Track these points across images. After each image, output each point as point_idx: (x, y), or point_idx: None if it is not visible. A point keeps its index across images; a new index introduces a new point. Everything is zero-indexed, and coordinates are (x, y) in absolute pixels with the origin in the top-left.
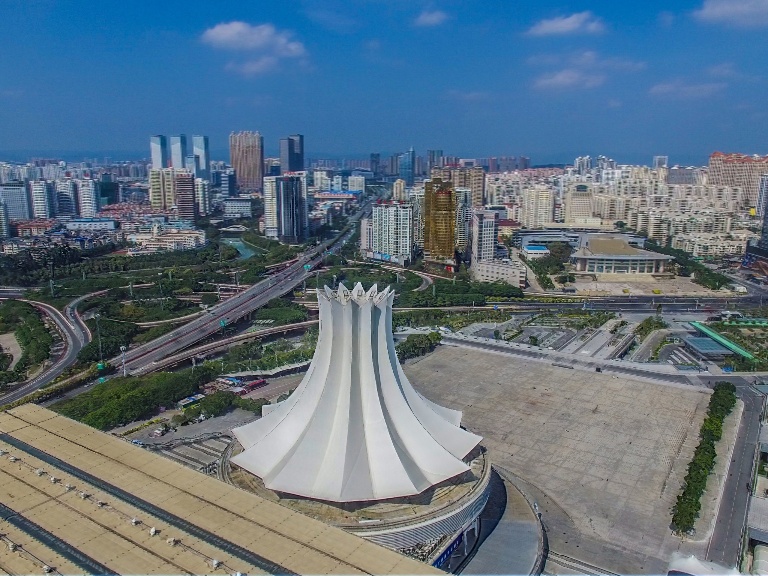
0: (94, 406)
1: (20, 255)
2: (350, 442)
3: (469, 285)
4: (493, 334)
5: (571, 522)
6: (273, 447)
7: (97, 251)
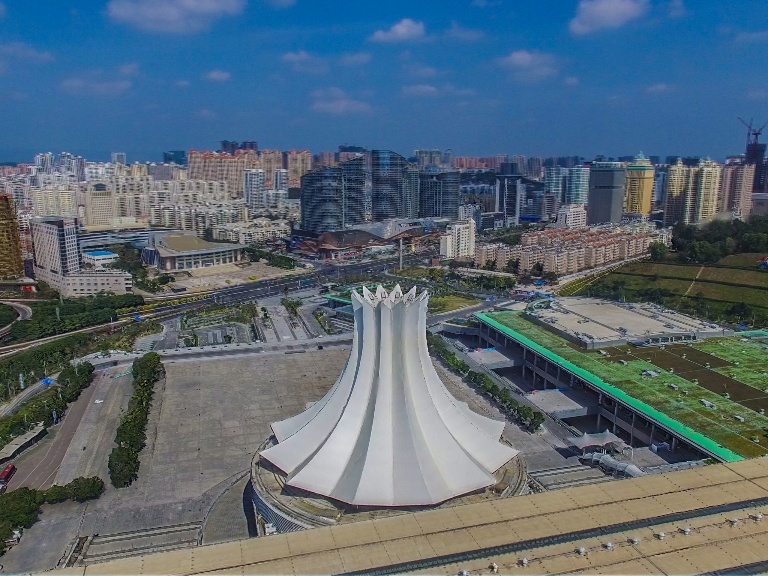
0: None
1: None
2: None
3: (76, 302)
4: (172, 344)
5: None
6: (377, 473)
7: None
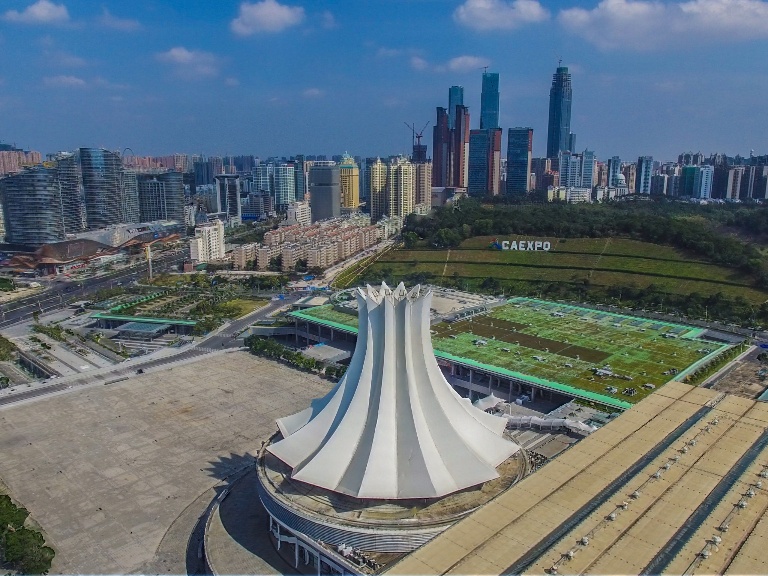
0: None
1: None
2: (469, 414)
3: None
4: None
5: None
6: None
7: None
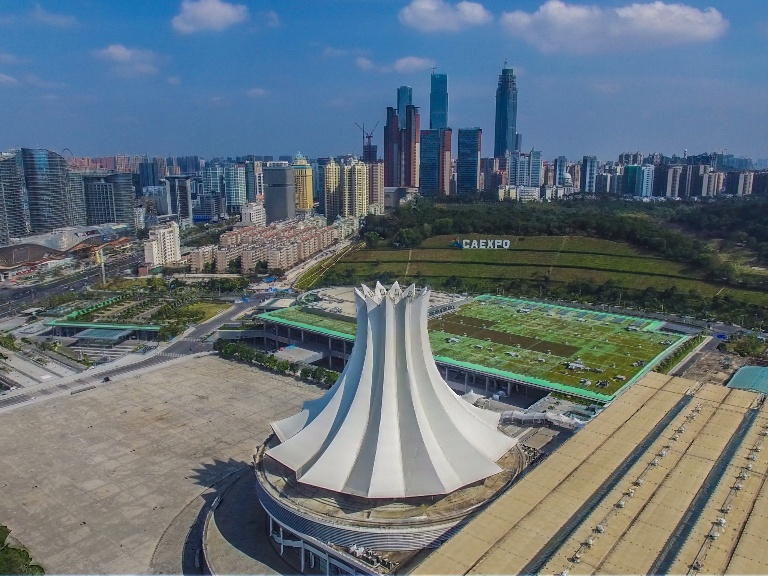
0: None
1: None
2: None
3: None
4: None
5: None
6: (438, 461)
7: None
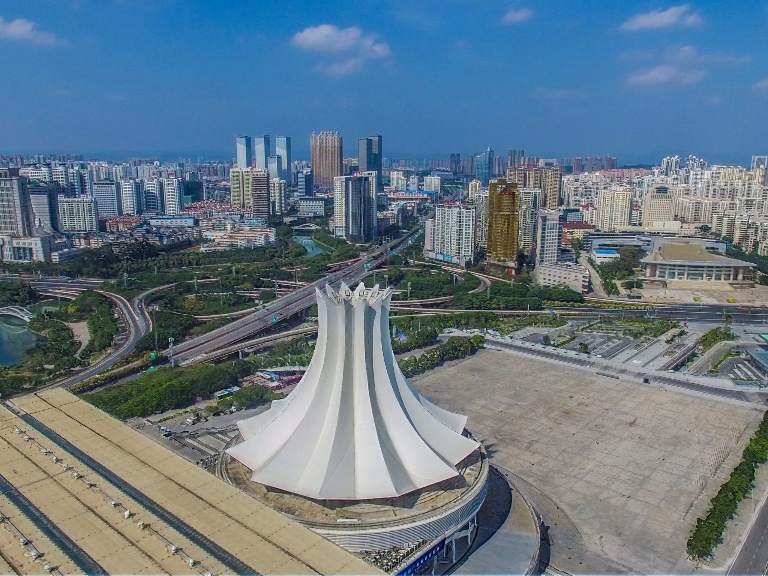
0: (138, 393)
1: (102, 249)
2: (337, 441)
3: (528, 288)
4: None
5: (579, 537)
6: (267, 441)
7: (174, 246)
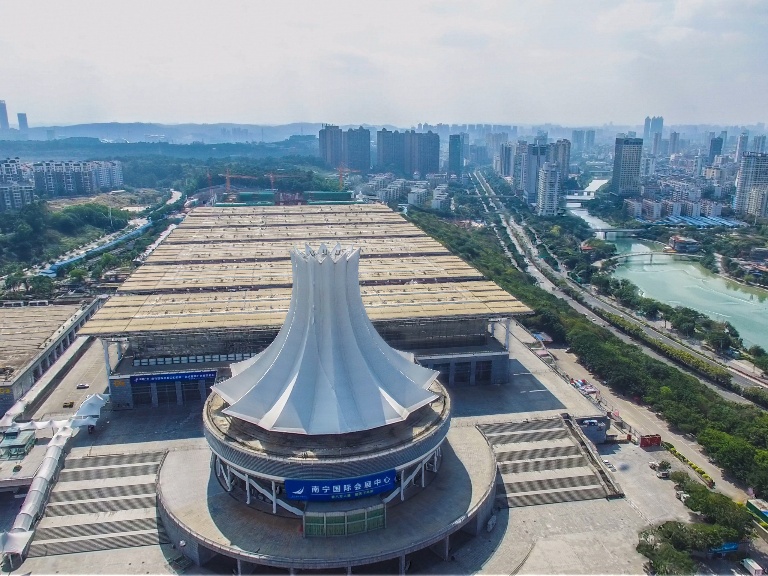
0: None
1: None
2: None
3: None
4: None
5: None
6: None
7: None
